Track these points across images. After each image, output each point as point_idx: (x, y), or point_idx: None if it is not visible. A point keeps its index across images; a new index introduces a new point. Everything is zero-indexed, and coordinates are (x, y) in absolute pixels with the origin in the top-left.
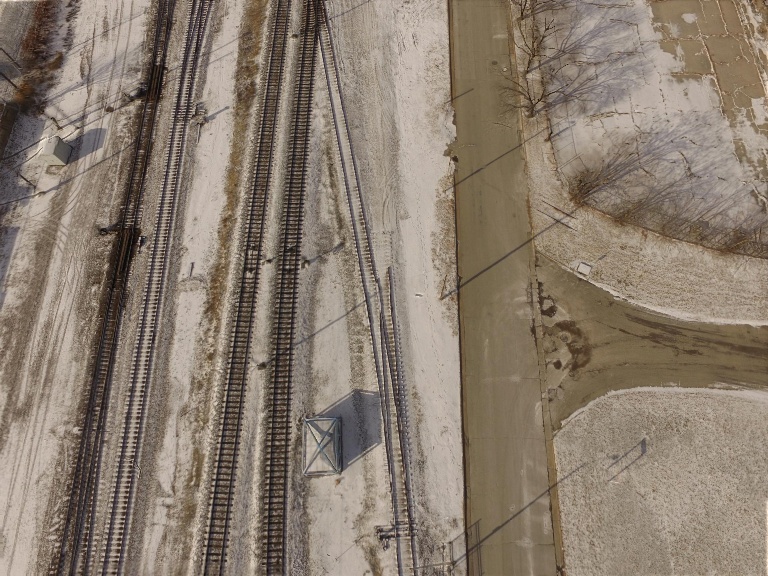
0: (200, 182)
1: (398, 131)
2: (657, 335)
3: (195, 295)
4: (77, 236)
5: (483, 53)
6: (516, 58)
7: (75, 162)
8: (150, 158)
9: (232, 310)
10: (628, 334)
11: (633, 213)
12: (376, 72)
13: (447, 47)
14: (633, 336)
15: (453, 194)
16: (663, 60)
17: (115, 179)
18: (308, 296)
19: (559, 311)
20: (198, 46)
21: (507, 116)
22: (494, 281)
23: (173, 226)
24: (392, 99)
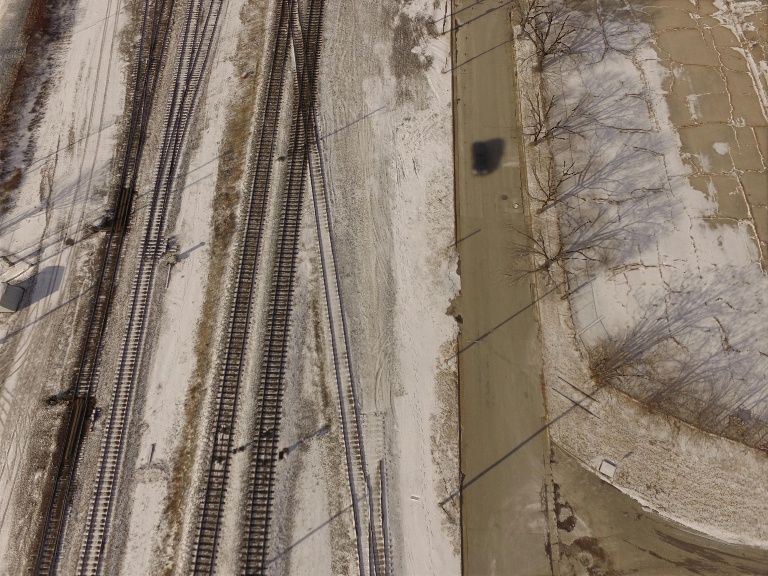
0: (167, 338)
1: (395, 281)
2: (694, 561)
3: (154, 488)
4: (22, 405)
5: (492, 185)
6: (529, 192)
7: (26, 308)
8: (112, 306)
9: (196, 513)
10: (660, 559)
11: (663, 396)
12: (371, 206)
13: (451, 177)
14: (666, 562)
15: (456, 365)
16: (693, 200)
17: (70, 332)
18: (286, 495)
19: (578, 524)
20: (173, 166)
21: (520, 284)
22: (503, 481)
23: (133, 396)
24: (389, 240)
